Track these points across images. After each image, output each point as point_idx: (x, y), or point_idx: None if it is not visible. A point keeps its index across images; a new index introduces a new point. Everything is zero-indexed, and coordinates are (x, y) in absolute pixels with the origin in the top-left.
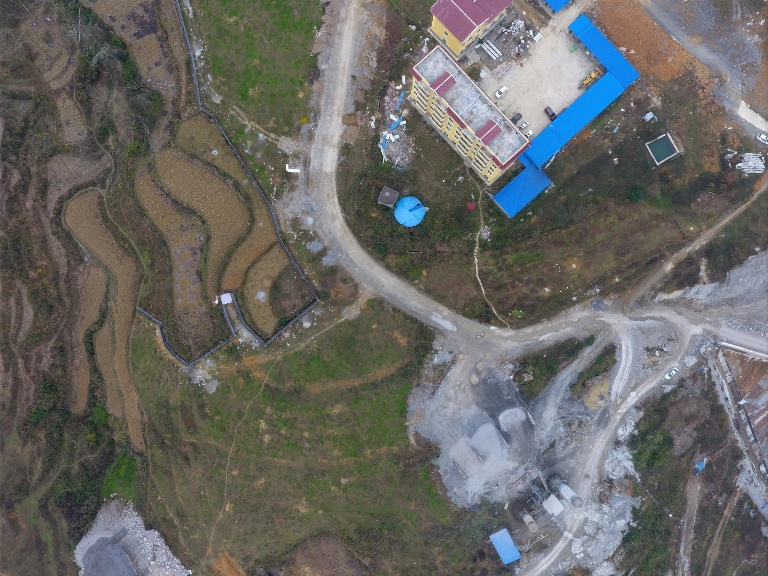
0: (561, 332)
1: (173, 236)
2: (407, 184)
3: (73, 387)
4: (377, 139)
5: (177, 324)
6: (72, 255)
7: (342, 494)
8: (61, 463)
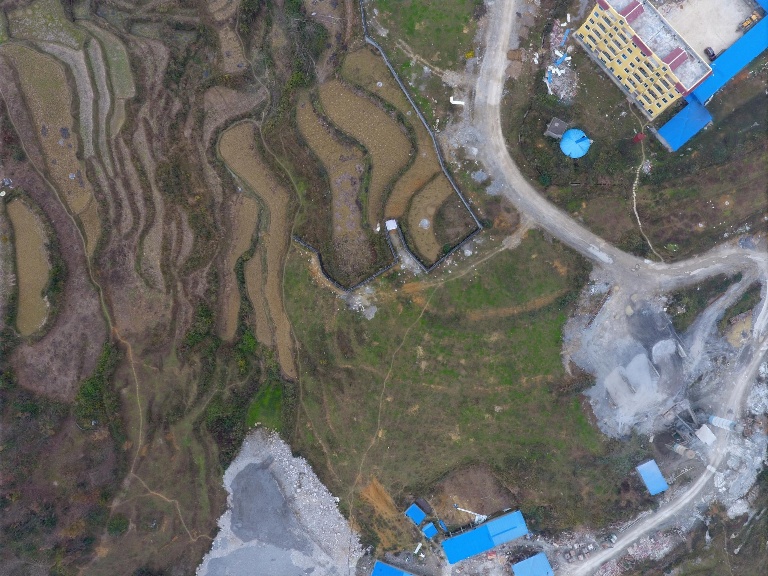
0: (711, 268)
1: (333, 166)
2: (573, 117)
3: (223, 314)
4: (543, 73)
5: (336, 251)
6: (227, 184)
7: (495, 422)
8: (214, 387)
